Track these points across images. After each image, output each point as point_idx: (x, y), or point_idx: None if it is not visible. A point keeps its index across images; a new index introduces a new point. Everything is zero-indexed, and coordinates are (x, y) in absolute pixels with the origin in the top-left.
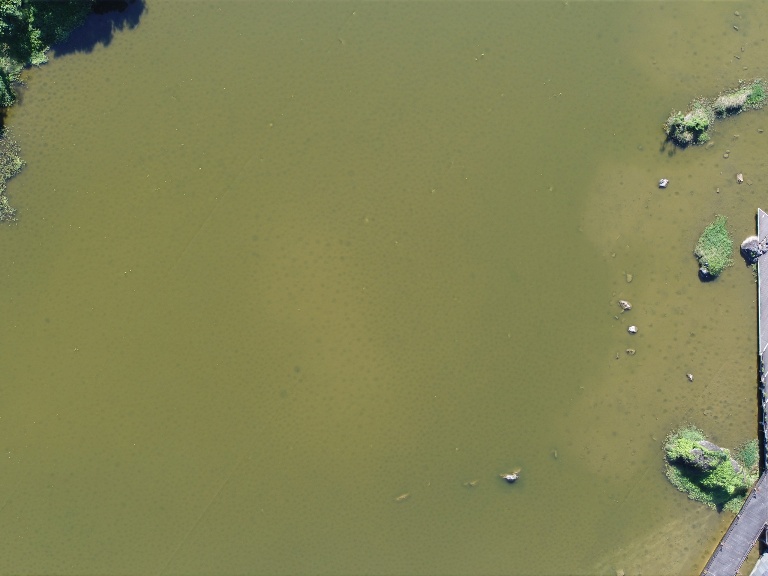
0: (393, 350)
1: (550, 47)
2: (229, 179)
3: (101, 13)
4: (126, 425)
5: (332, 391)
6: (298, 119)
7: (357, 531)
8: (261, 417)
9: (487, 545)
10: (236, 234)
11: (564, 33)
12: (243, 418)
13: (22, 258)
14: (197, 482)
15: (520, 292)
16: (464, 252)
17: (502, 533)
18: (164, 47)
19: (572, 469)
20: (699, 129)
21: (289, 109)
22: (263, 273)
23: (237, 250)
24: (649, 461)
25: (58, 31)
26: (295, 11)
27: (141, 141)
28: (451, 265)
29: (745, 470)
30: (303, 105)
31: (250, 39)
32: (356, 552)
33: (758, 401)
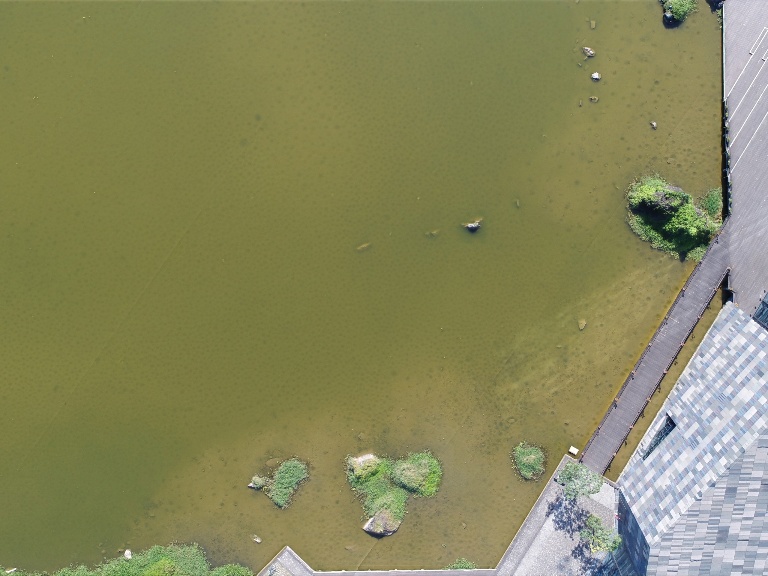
0: (354, 98)
1: None
2: None
3: None
4: (86, 174)
5: (293, 139)
6: None
7: (318, 281)
8: (222, 166)
9: (448, 295)
10: None
11: None
12: (203, 167)
13: None
14: (157, 231)
15: (482, 39)
16: None
17: (464, 283)
18: None
19: (534, 219)
20: None
21: None
22: (223, 20)
23: None
24: (612, 210)
25: None
26: None
27: None
28: (413, 11)
29: (708, 216)
30: None
31: None
32: (317, 302)
33: (722, 149)
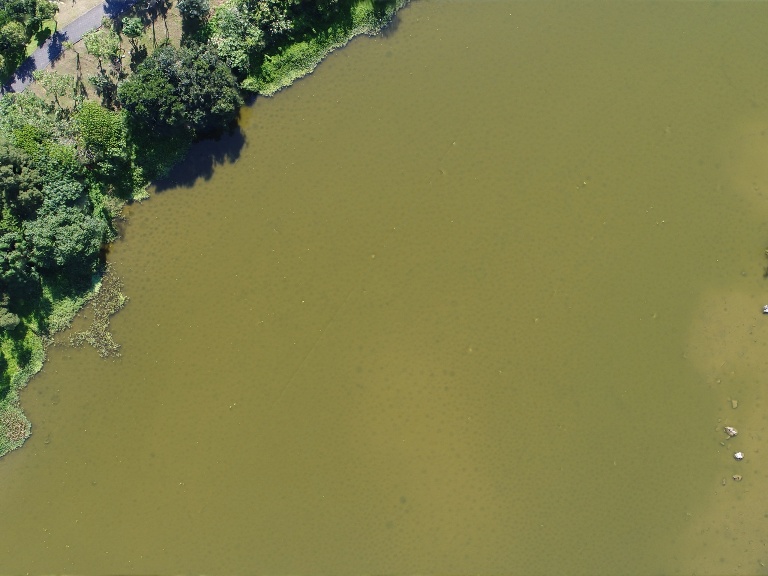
0: (499, 479)
1: (651, 174)
2: (332, 311)
3: (197, 141)
4: (233, 558)
5: (438, 521)
6: (400, 250)
7: None
8: (368, 548)
9: None
10: (340, 366)
11: (665, 160)
12: (350, 550)
13: (126, 393)
14: None
15: (625, 420)
16: (568, 380)
17: None
18: (265, 180)
19: None
20: None
21: (391, 240)
22: (367, 405)
23: (341, 382)
24: None
25: (160, 167)
26: (395, 142)
27: (243, 274)
28: (556, 394)
29: None
30: (405, 236)
31: (351, 171)
32: None
33: None
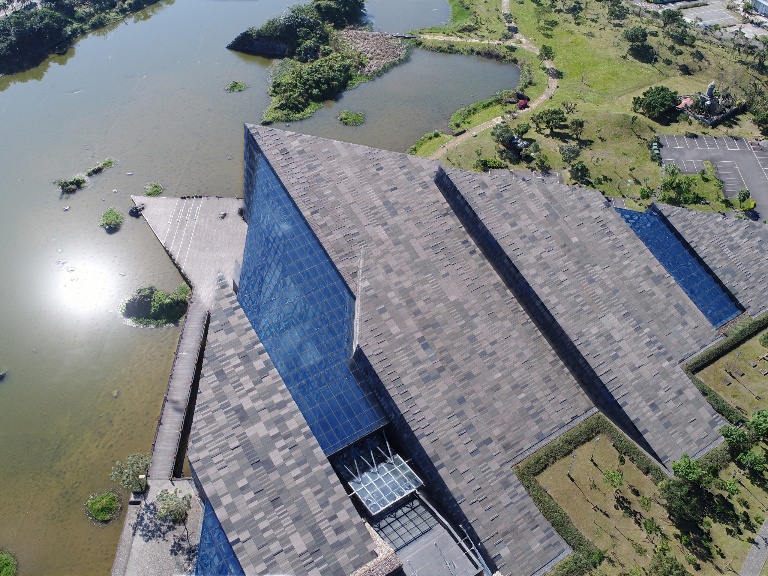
0: None
1: None
2: None
3: None
4: None
5: None
6: None
7: None
8: None
9: None
10: None
11: None
12: None
13: None
14: None
15: None
16: None
17: (1, 414)
18: None
19: None
20: (76, 181)
21: None
22: None
23: None
24: (111, 324)
25: None
26: None
27: None
28: None
29: None
30: None
31: None
32: None
33: (175, 266)
